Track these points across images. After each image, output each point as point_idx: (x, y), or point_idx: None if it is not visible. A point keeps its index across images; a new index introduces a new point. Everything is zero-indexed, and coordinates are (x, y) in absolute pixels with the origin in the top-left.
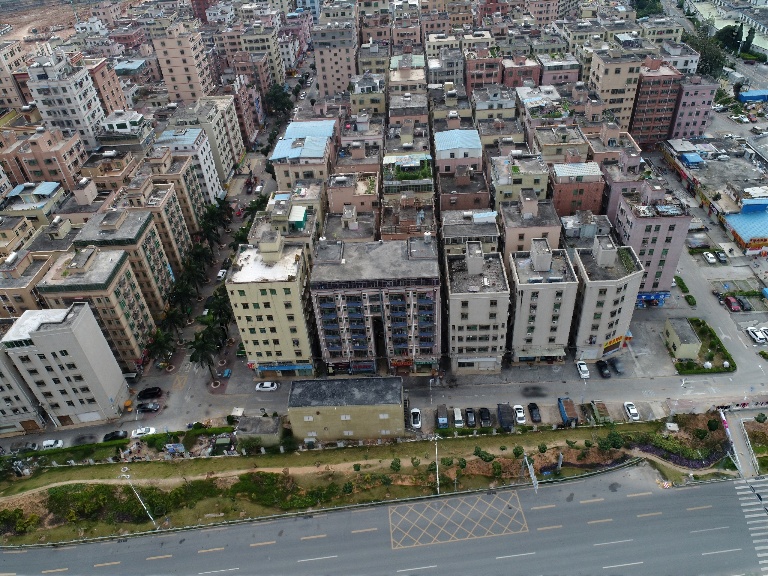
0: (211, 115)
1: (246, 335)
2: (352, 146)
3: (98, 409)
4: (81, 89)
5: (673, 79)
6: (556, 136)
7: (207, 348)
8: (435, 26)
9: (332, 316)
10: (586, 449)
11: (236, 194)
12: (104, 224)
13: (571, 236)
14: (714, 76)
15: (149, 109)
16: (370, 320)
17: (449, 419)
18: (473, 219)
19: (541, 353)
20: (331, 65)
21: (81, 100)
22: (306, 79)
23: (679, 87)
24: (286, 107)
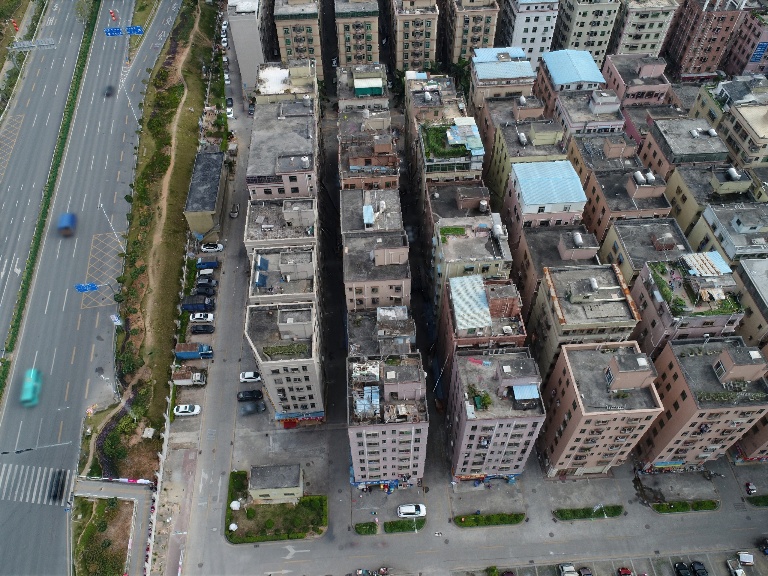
0: None
1: None
2: None
3: None
4: None
5: None
6: None
7: None
8: None
9: None
10: None
11: None
12: None
13: None
14: None
15: None
16: None
17: None
18: None
19: None
20: None
21: None
22: None
23: None
24: None
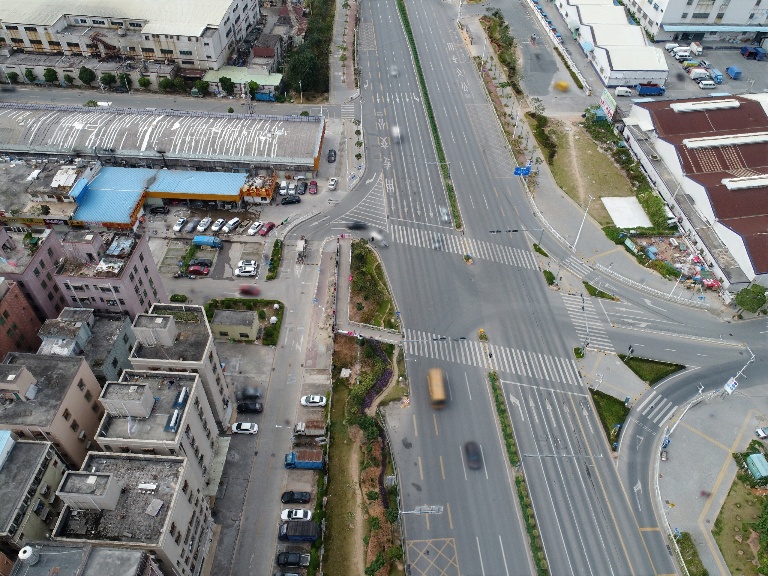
0: None
1: None
2: None
3: None
4: None
5: None
6: None
7: None
8: None
9: None
10: (369, 454)
11: None
12: None
13: None
14: None
15: None
16: None
17: None
18: None
19: (219, 464)
20: None
21: None
22: None
23: None
24: None
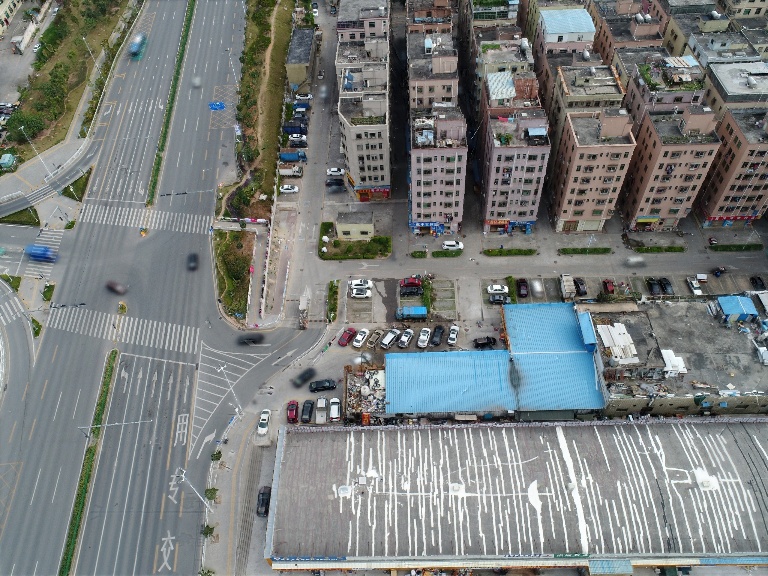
0: None
1: None
2: None
3: None
4: None
5: None
6: None
7: None
8: None
9: None
10: None
11: None
12: None
13: None
14: None
15: None
16: None
17: None
18: (435, 46)
19: None
20: None
21: None
22: None
23: None
24: None
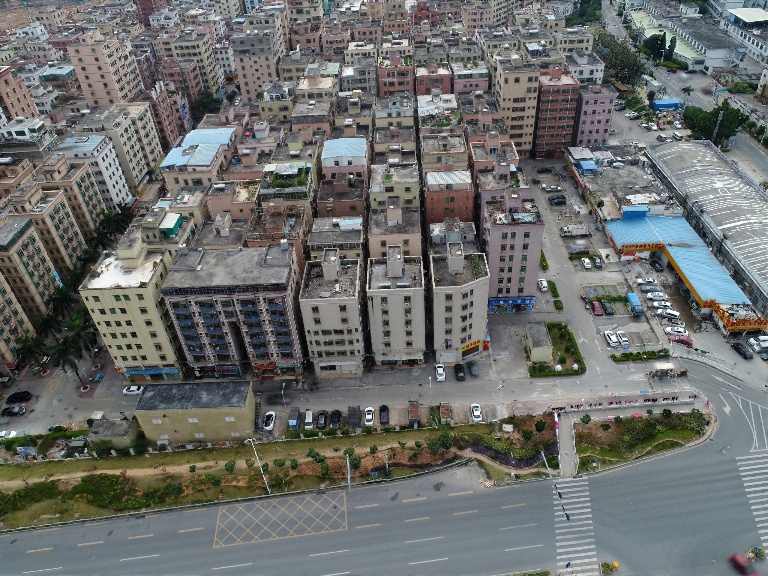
0: (118, 122)
1: (108, 340)
2: (242, 154)
3: None
4: None
5: (571, 88)
6: (439, 145)
7: (70, 353)
8: (367, 33)
9: (188, 321)
10: (418, 450)
11: (148, 200)
12: None
13: (438, 243)
14: (632, 84)
15: (66, 115)
16: (226, 325)
17: (302, 421)
18: None
19: (399, 357)
20: (252, 72)
21: None
22: None
23: (580, 96)
24: None
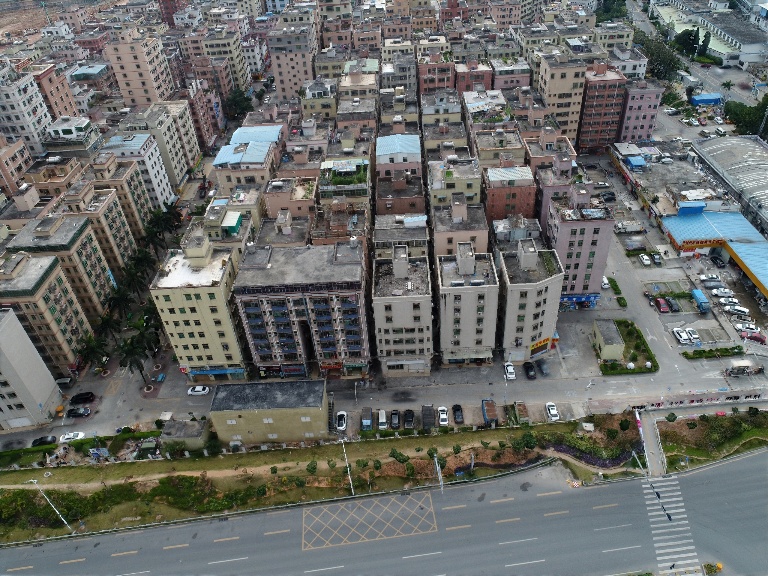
0: (161, 120)
1: (175, 340)
2: (294, 151)
3: (27, 414)
4: (25, 95)
5: (618, 83)
6: (494, 141)
7: (136, 353)
8: (397, 30)
9: (258, 320)
10: (501, 449)
11: (189, 199)
12: (38, 230)
13: (502, 239)
14: (668, 80)
15: (104, 114)
16: (296, 324)
17: (374, 421)
18: (405, 223)
19: (469, 355)
20: (288, 70)
21: (25, 106)
22: (271, 83)
23: (625, 91)
24: (246, 111)
